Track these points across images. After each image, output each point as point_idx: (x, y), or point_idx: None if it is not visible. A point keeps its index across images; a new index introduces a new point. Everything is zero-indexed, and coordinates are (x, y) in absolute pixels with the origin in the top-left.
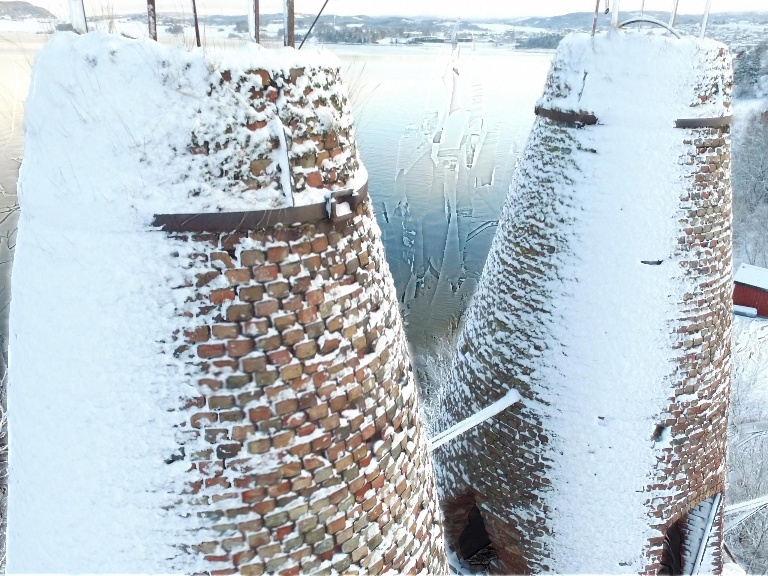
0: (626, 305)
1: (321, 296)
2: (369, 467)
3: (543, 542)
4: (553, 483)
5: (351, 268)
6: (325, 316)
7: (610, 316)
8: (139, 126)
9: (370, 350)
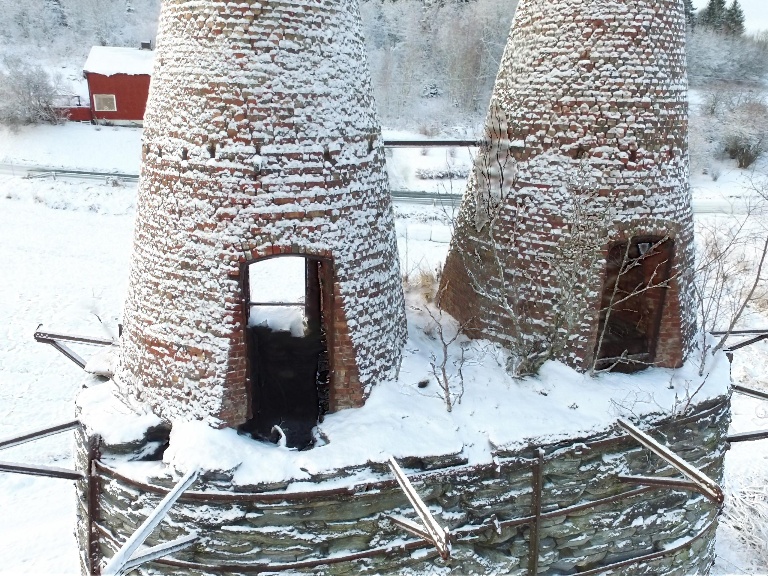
0: None
1: None
2: None
3: None
4: None
5: None
6: None
7: None
8: None
9: None
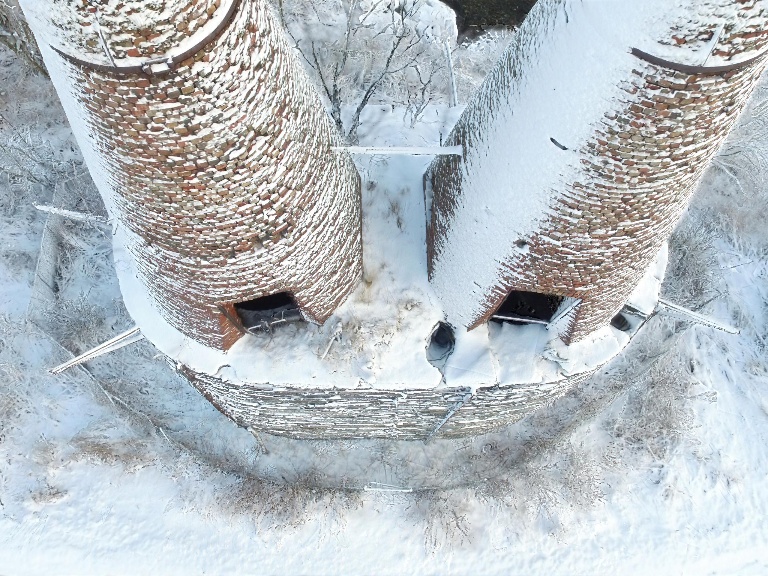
0: (526, 158)
1: (147, 107)
2: (192, 180)
3: (443, 239)
4: (456, 217)
5: (173, 96)
6: (151, 116)
7: (514, 156)
8: (30, 2)
9: (194, 133)
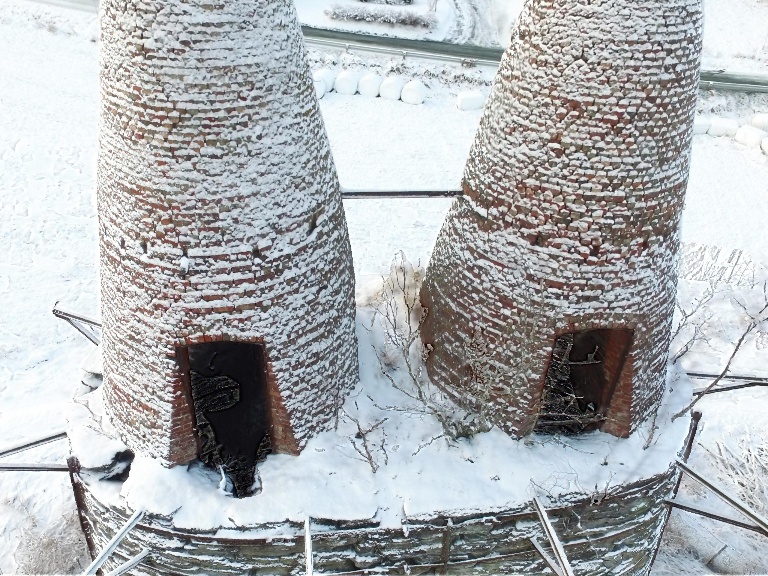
0: None
1: None
2: None
3: None
4: None
5: None
6: None
7: None
8: None
9: None
